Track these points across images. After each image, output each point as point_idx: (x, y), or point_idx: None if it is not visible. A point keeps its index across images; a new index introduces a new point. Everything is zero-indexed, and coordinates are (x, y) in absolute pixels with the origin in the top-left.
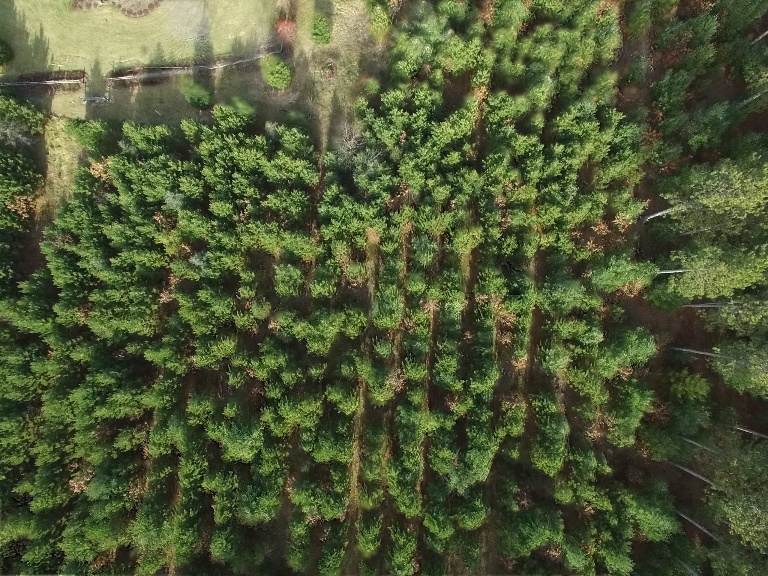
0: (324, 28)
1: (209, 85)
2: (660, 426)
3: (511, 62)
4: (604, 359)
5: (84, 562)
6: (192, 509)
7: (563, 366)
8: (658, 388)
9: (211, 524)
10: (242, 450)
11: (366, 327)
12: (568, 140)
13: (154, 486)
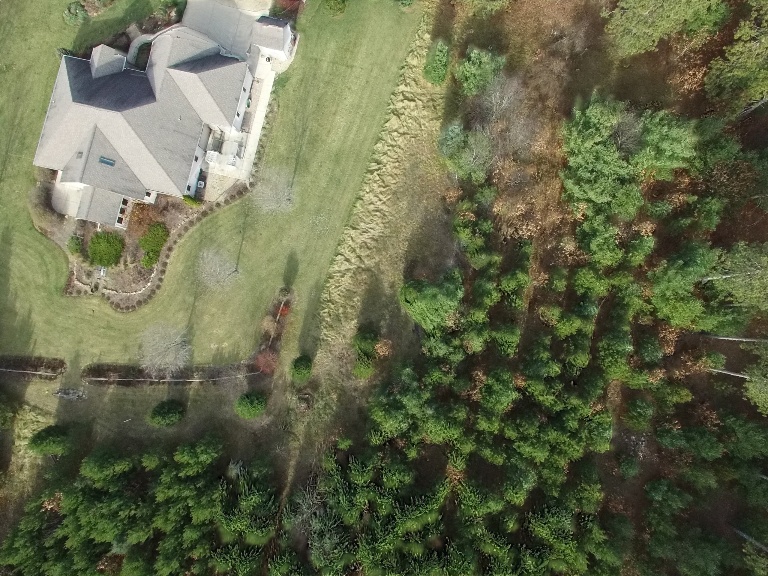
0: (304, 369)
1: (183, 397)
2: None
3: (489, 449)
4: None
5: None
6: None
7: None
8: None
9: None
10: None
11: None
12: (537, 543)
13: None
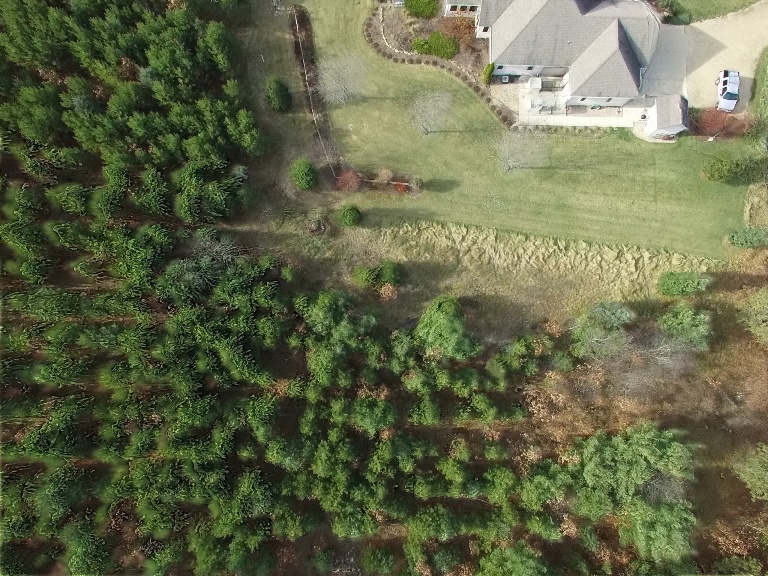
0: None
1: (295, 108)
2: None
3: (314, 416)
4: None
5: None
6: None
7: None
8: None
9: None
10: None
11: None
12: (233, 484)
13: None
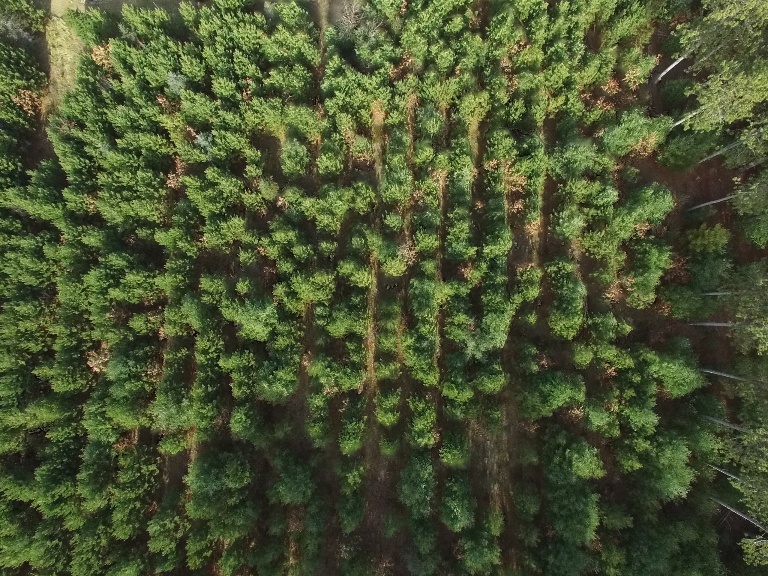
0: None
1: None
2: (681, 283)
3: None
4: (620, 218)
5: (107, 442)
6: (210, 385)
7: (578, 233)
8: (677, 244)
9: (230, 400)
10: (257, 327)
11: (375, 206)
12: None
13: (171, 364)
